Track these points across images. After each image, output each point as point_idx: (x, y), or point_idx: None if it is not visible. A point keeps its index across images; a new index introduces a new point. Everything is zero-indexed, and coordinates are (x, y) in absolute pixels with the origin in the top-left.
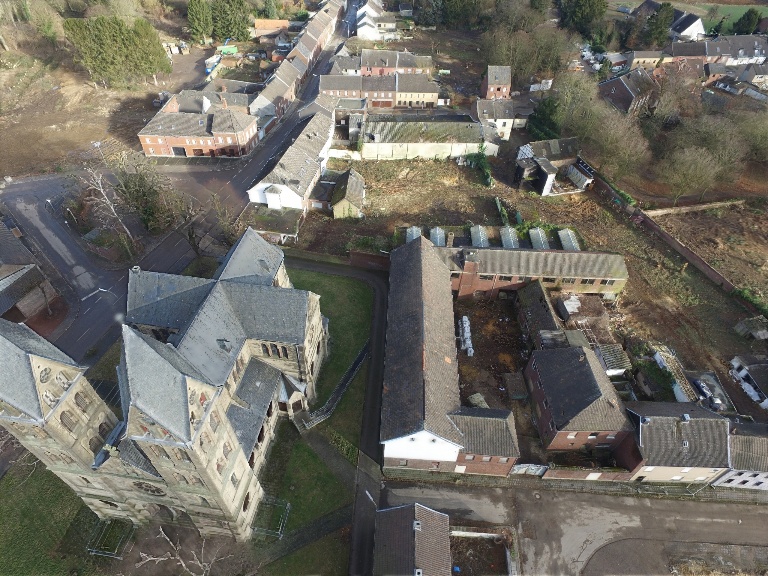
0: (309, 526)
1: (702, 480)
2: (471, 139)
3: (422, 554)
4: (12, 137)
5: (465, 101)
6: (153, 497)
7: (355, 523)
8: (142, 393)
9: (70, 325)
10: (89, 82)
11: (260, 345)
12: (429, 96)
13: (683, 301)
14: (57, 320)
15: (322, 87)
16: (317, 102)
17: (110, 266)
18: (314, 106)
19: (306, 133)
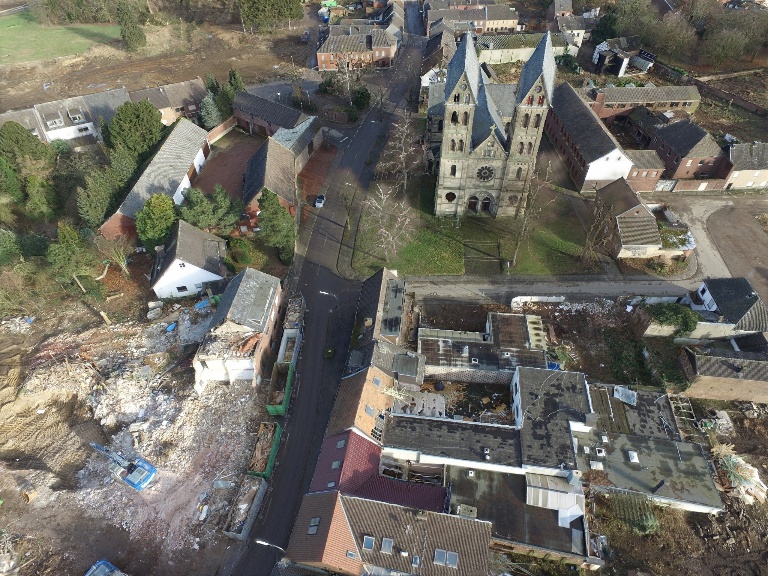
0: (551, 213)
1: (764, 186)
2: (559, 44)
3: (634, 192)
4: (209, 66)
5: (537, 26)
6: (482, 184)
7: (576, 212)
8: (545, 69)
9: (344, 152)
10: (235, 31)
11: (505, 124)
12: (511, 22)
13: (733, 120)
14: (334, 151)
15: (430, 19)
16: (444, 22)
17: (345, 126)
18: (442, 26)
19: (444, 43)
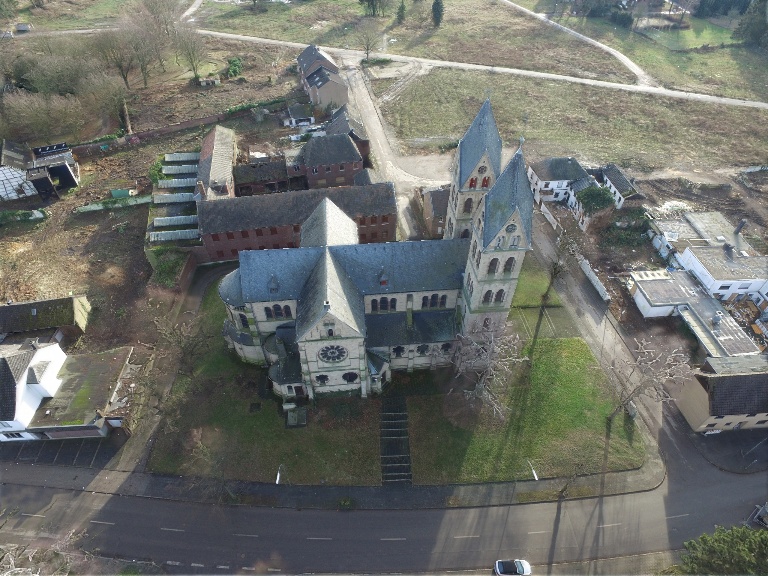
0: None
1: None
2: None
3: None
4: None
5: None
6: None
7: None
8: None
9: (305, 574)
10: None
11: None
12: None
13: None
14: None
15: None
16: None
17: None
18: None
19: None
